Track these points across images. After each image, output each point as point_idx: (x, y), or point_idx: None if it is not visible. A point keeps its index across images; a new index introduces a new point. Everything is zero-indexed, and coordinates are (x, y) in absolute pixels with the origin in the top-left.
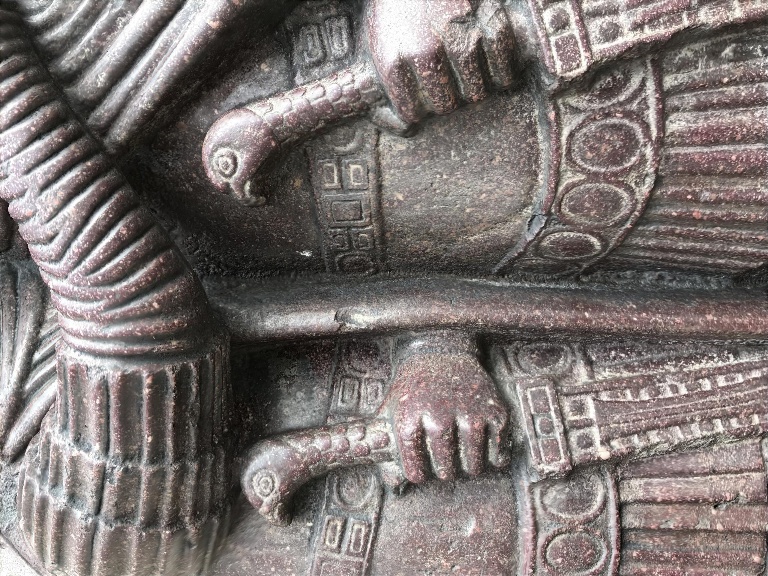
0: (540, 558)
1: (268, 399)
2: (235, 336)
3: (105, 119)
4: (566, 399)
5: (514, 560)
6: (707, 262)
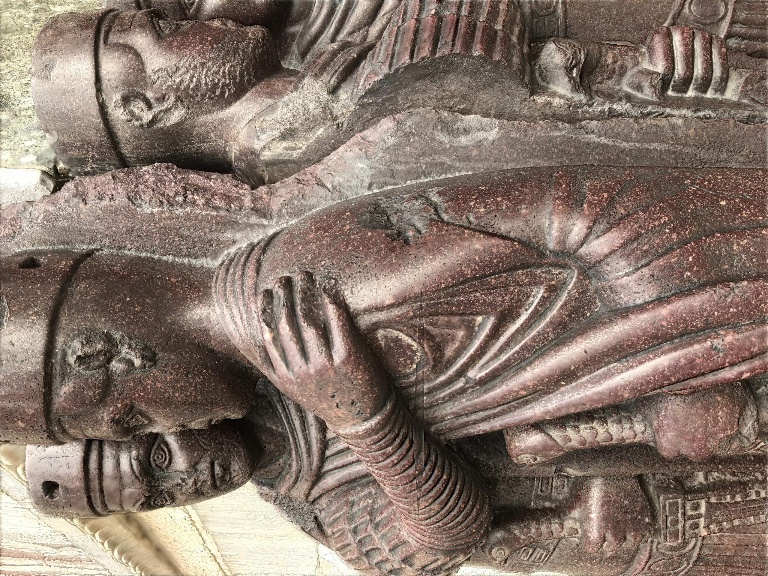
0: (647, 568)
1: (490, 485)
2: None
3: (445, 431)
4: (689, 502)
5: (630, 565)
6: None
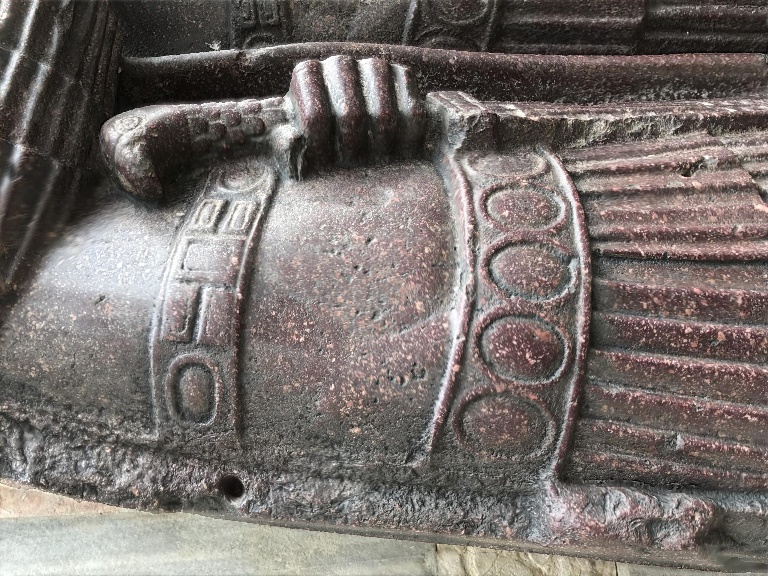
0: (480, 212)
1: None
2: (129, 65)
3: None
4: None
5: (448, 229)
6: (591, 22)
